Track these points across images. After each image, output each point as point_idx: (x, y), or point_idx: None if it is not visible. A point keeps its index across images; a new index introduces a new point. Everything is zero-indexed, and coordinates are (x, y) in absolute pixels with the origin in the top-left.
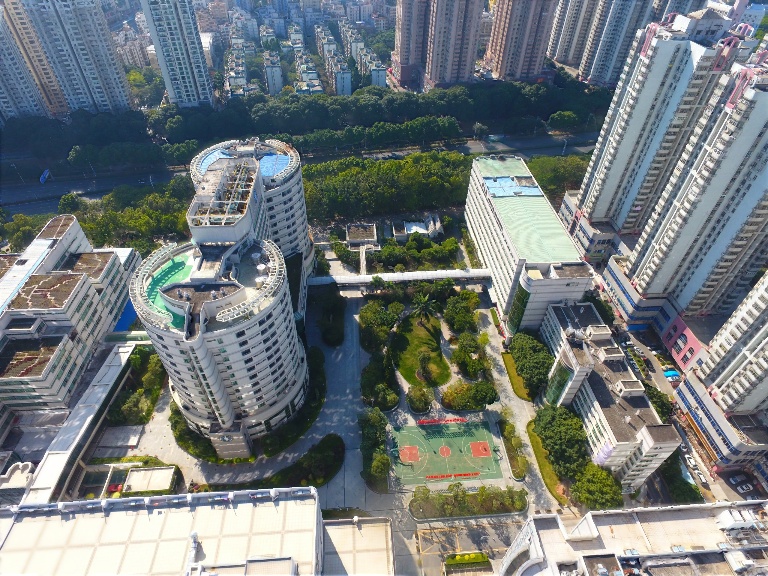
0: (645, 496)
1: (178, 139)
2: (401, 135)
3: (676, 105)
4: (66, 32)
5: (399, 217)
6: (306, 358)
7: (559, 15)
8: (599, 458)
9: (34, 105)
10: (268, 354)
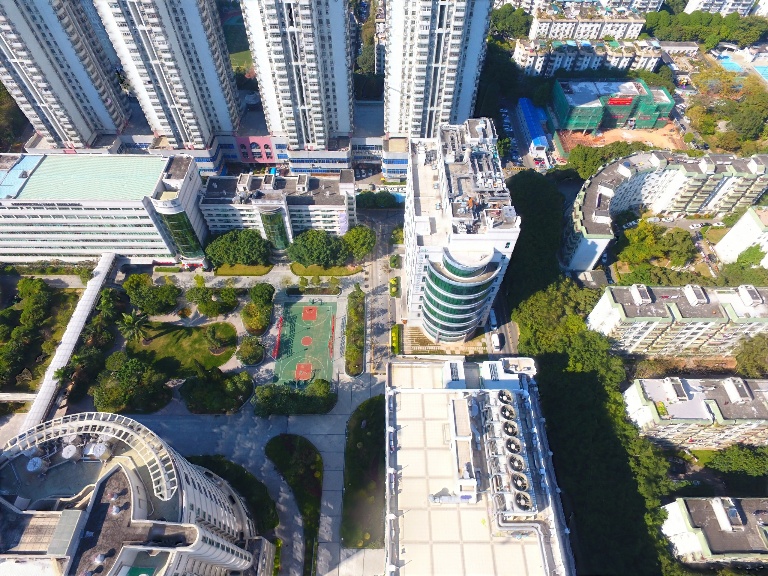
0: (362, 222)
1: None
2: None
3: None
4: None
5: None
6: None
7: None
8: (343, 228)
9: None
10: None
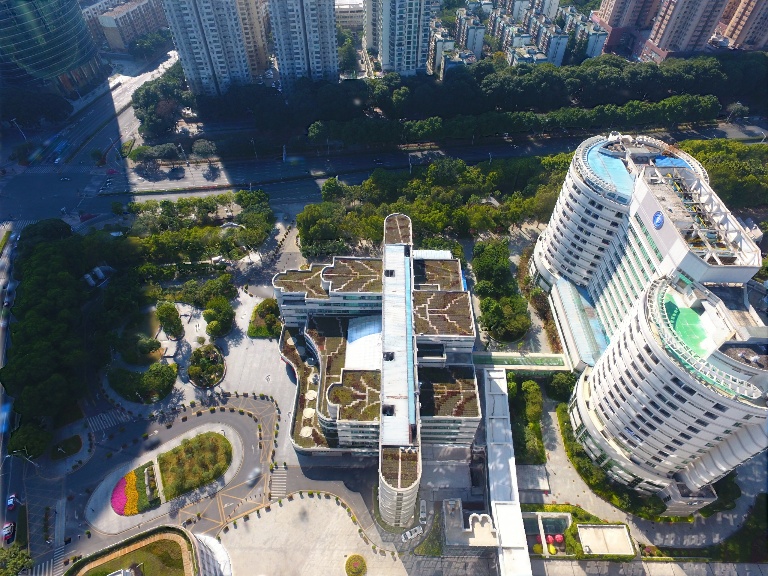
0: None
1: (402, 113)
2: (658, 116)
3: None
4: None
5: None
6: None
7: None
8: None
9: (245, 70)
10: None
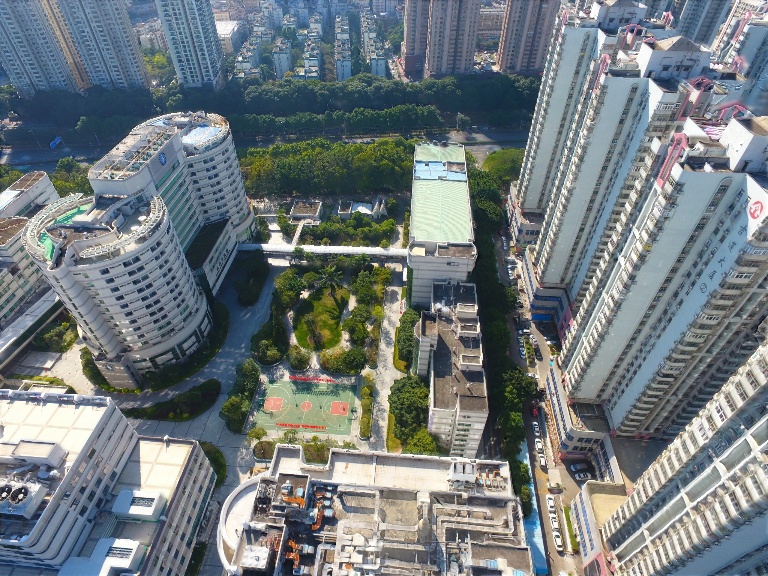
0: None
1: None
2: (379, 121)
3: None
4: (87, 15)
5: (352, 198)
6: (208, 311)
7: (578, 8)
8: (428, 425)
9: (63, 80)
10: (142, 295)
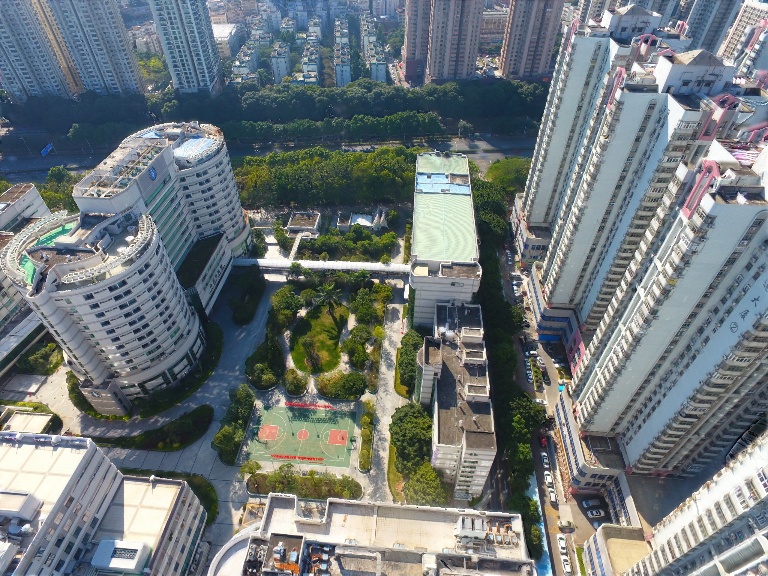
0: (485, 505)
1: None
2: (379, 129)
3: None
4: (79, 19)
5: (352, 209)
6: (201, 332)
7: (581, 12)
8: (432, 459)
9: (55, 86)
10: (129, 320)
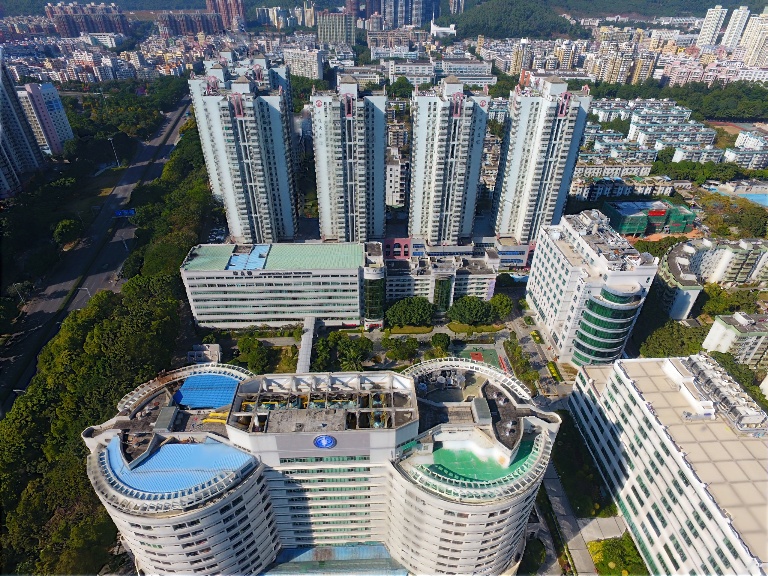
0: None
1: None
2: None
3: (282, 138)
4: None
5: None
6: None
7: None
8: (490, 294)
9: None
10: None
